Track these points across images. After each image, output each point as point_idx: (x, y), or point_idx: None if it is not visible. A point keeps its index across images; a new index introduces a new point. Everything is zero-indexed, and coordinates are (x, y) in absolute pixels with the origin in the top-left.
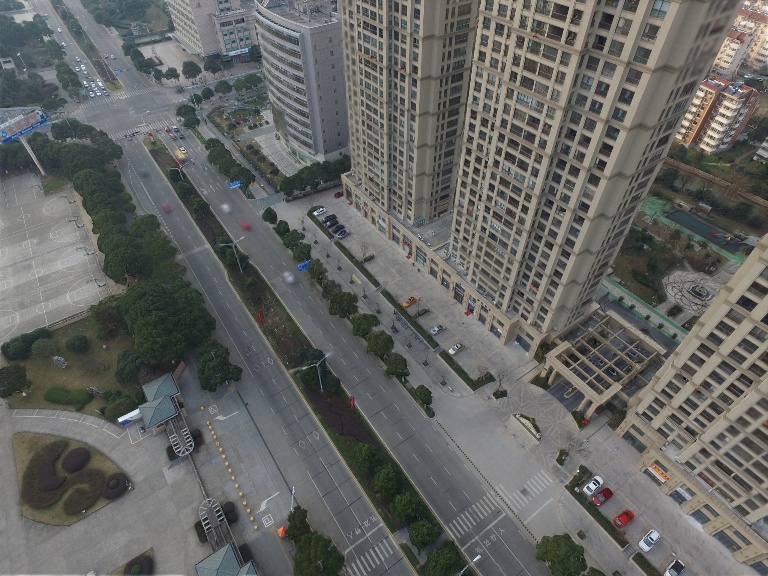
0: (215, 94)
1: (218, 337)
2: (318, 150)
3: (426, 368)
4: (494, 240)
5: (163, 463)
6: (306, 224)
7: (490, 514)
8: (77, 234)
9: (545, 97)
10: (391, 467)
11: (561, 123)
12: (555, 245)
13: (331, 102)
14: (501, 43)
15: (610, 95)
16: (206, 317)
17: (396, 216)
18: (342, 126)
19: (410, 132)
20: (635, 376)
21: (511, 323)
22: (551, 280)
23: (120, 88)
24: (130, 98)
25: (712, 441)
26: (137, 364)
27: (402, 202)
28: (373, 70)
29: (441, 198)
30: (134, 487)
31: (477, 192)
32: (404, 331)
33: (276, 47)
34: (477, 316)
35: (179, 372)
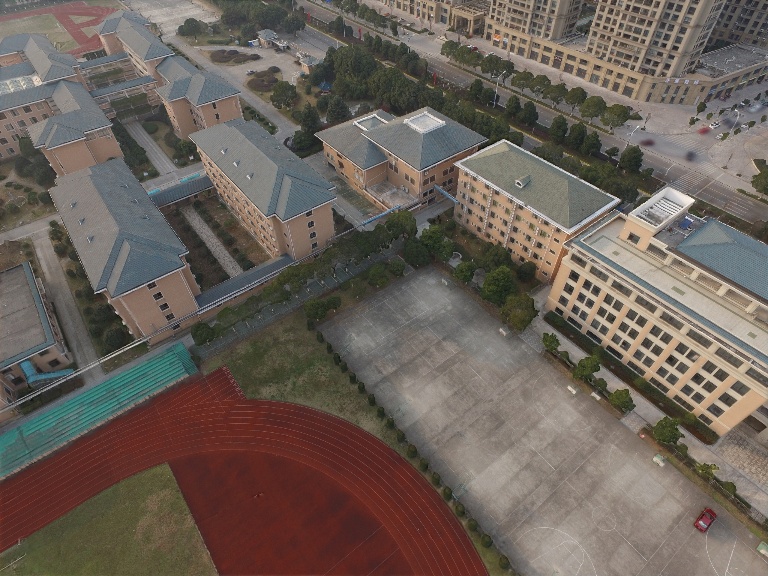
0: None
1: None
2: None
3: None
4: None
5: (274, 53)
6: None
7: (424, 57)
8: (193, 5)
9: None
10: (380, 37)
11: None
12: None
13: None
14: None
15: None
16: None
17: None
18: None
19: None
20: None
21: (436, 3)
22: None
23: None
24: None
25: (510, 0)
26: (253, 24)
27: None
28: None
29: None
30: (263, 58)
31: None
32: None
33: None
34: (421, 15)
35: None
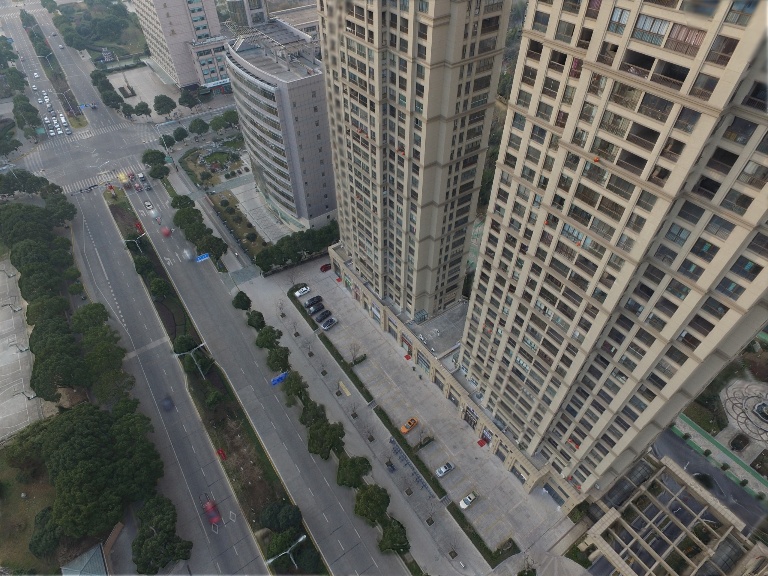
0: (190, 134)
1: (168, 479)
2: (302, 214)
3: (431, 528)
4: (519, 377)
5: None
6: (286, 308)
7: None
8: (12, 321)
9: (608, 240)
10: None
11: (631, 277)
12: (607, 410)
13: (316, 163)
14: (540, 152)
15: (718, 262)
16: (150, 462)
17: (393, 307)
18: (329, 187)
19: (410, 222)
20: (705, 561)
21: (540, 476)
22: (597, 442)
23: (85, 125)
24: (95, 137)
25: None
26: (56, 535)
27: (400, 294)
28: (363, 146)
29: (448, 289)
30: None
31: (497, 315)
32: (403, 469)
33: (249, 99)
34: (494, 450)
35: (114, 537)
